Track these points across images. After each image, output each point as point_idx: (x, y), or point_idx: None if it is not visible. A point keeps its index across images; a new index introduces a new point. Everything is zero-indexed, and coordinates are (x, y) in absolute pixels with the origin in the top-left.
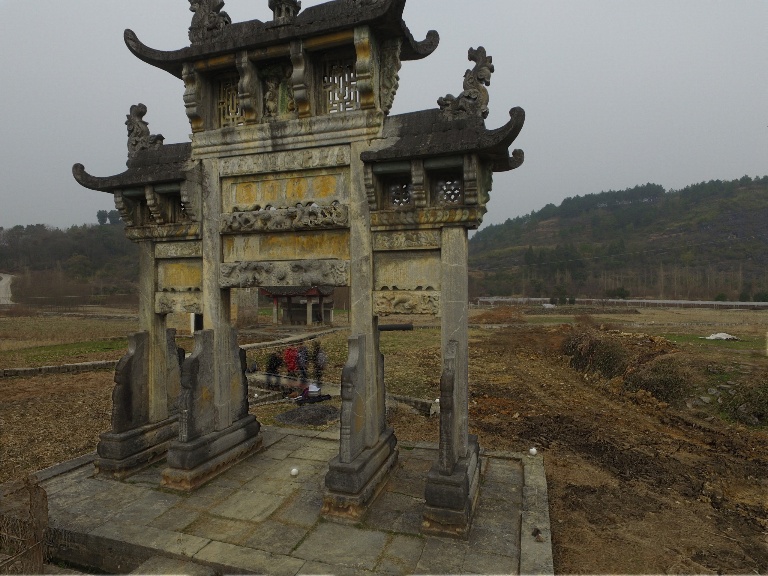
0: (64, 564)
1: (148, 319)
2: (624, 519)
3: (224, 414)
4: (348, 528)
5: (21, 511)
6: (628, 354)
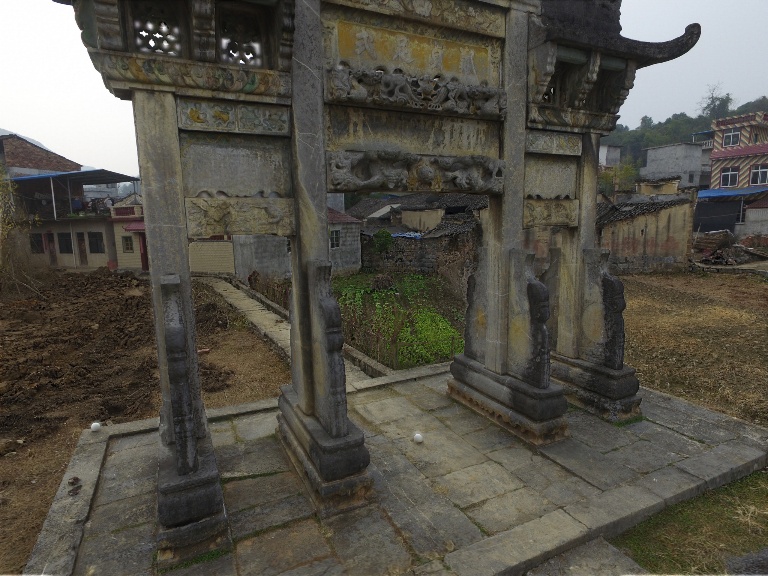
0: None
1: None
2: None
3: (491, 353)
4: None
5: None
6: None
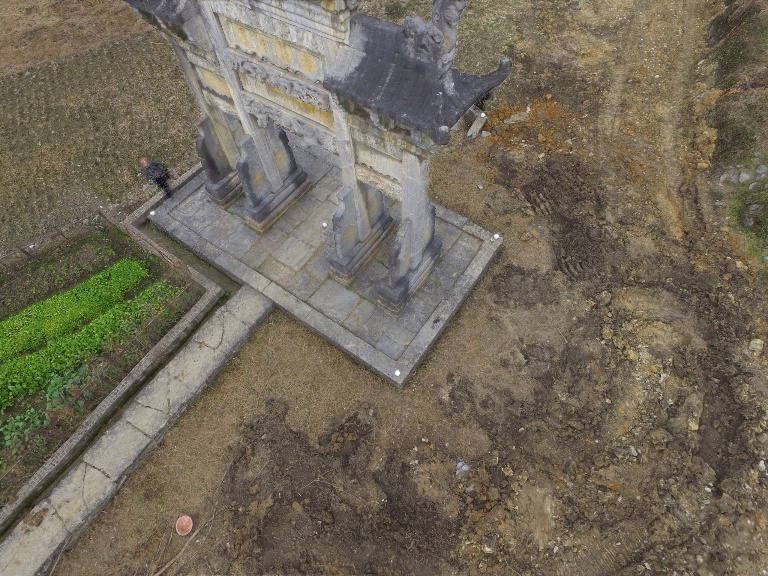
0: (209, 265)
1: (204, 107)
2: (518, 306)
3: (276, 183)
4: (341, 287)
5: (179, 232)
6: (760, 58)
